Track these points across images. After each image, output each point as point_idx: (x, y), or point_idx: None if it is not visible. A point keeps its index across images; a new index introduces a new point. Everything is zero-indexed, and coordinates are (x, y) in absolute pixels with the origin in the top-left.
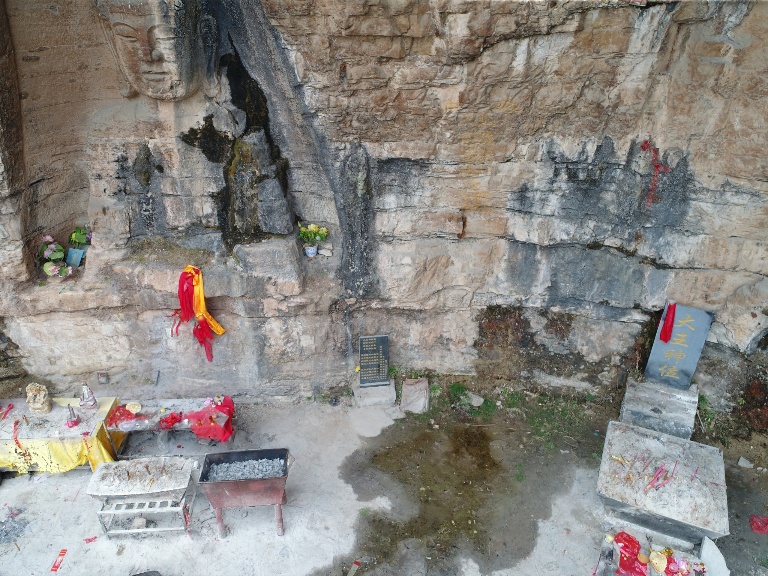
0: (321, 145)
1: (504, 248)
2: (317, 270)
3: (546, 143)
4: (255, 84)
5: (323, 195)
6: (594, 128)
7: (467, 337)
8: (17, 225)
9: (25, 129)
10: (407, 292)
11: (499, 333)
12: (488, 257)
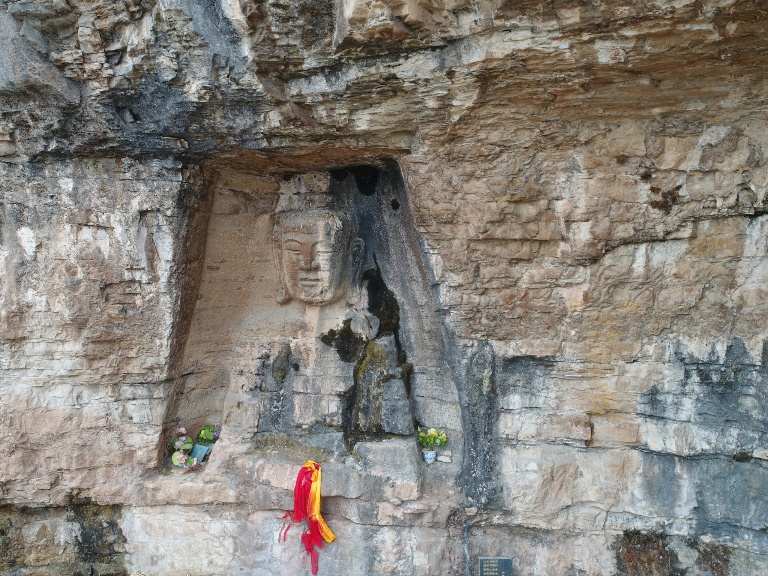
0: (450, 342)
1: (637, 460)
2: (435, 476)
3: (672, 344)
4: (391, 294)
5: (444, 399)
6: (721, 328)
7: (603, 570)
8: (162, 410)
9: (192, 325)
10: (533, 503)
11: (641, 567)
12: (620, 470)
